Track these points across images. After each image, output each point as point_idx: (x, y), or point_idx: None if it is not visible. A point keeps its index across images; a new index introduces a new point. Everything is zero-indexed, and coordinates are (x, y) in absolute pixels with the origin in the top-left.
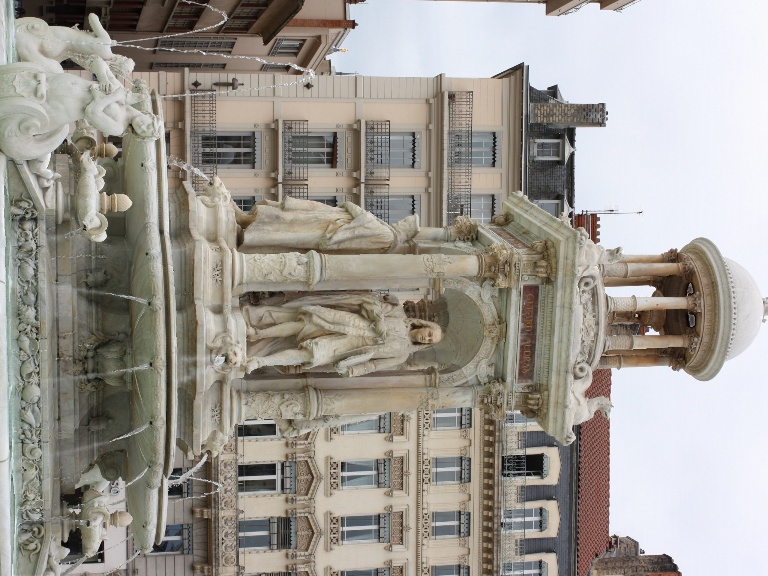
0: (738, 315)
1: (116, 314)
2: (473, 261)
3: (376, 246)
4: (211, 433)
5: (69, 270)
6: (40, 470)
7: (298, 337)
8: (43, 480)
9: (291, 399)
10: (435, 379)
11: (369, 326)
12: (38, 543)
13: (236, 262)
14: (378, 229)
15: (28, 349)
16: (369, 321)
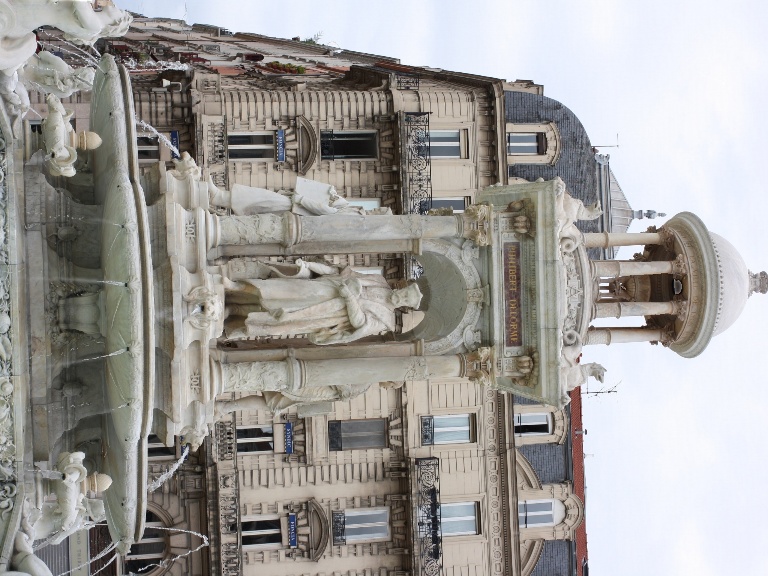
0: None
1: (89, 428)
2: None
3: None
4: None
5: None
6: None
7: None
8: None
9: None
10: None
11: None
12: None
13: None
14: (372, 332)
15: None
16: (336, 391)
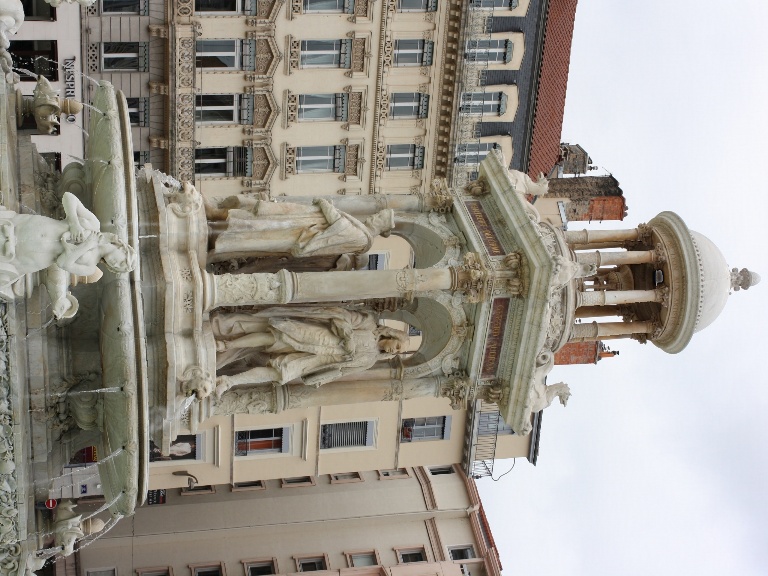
0: (704, 307)
1: (87, 351)
2: (446, 278)
3: (349, 250)
4: None
5: (39, 324)
6: (16, 523)
7: (267, 350)
8: (20, 531)
9: (258, 399)
10: (400, 373)
11: (338, 344)
12: (15, 562)
13: (207, 291)
14: (352, 235)
15: (2, 433)
16: (338, 338)
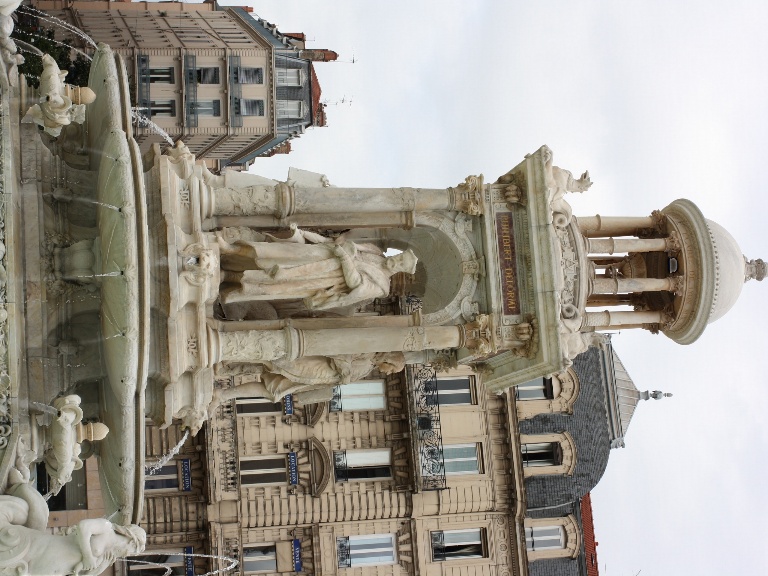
0: None
1: (86, 403)
2: (454, 344)
3: None
4: None
5: None
6: None
7: None
8: None
9: (249, 372)
10: None
11: (334, 377)
12: None
13: (211, 363)
14: (368, 296)
15: None
16: (336, 371)
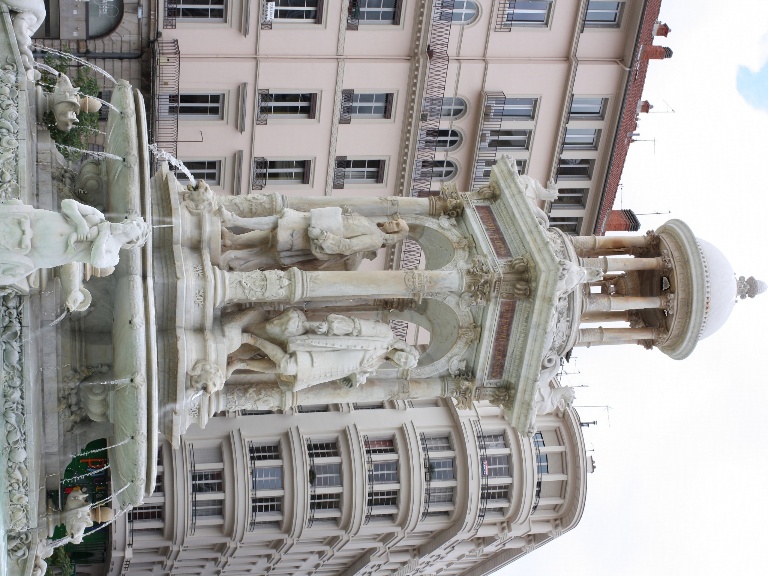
0: None
1: None
2: None
3: None
4: (202, 348)
5: None
6: (17, 156)
7: None
8: (19, 160)
9: None
10: None
11: None
12: None
13: None
14: None
15: None
16: None
